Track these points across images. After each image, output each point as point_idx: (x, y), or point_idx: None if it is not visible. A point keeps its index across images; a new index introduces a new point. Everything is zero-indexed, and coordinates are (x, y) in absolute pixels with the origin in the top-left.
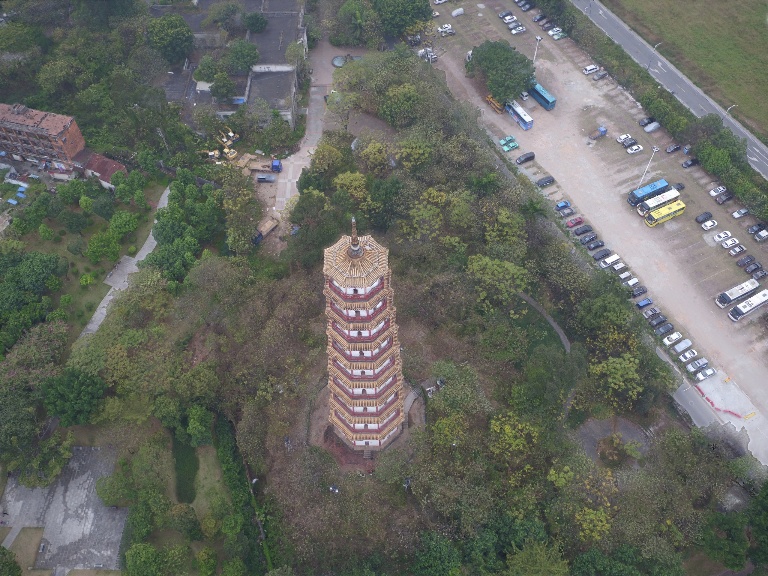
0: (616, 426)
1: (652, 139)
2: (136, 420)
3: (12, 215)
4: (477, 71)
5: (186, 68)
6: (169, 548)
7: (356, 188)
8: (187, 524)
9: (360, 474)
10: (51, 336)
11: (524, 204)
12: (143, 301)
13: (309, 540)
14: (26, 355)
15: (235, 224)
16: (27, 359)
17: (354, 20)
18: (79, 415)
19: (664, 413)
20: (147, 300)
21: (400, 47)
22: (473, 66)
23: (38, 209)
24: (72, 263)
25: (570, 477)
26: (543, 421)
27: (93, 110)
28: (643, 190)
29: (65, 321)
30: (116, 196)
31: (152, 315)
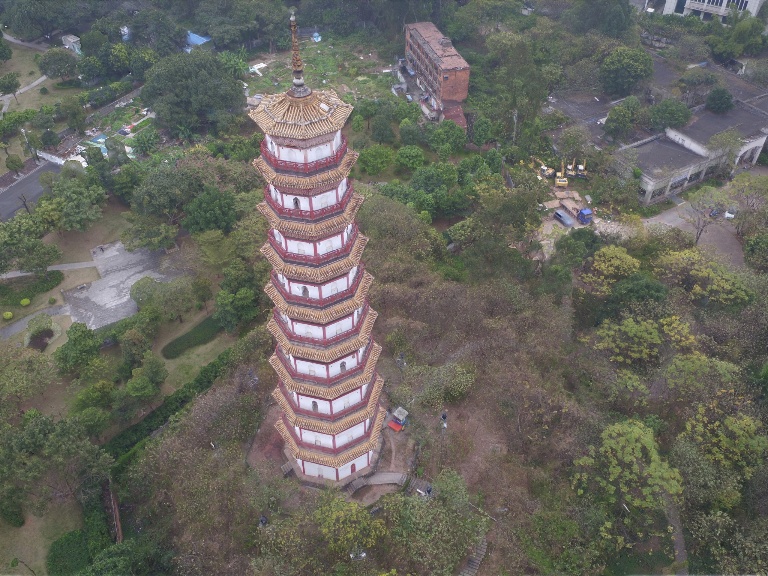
0: None
1: None
2: None
3: (358, 102)
4: None
5: (615, 104)
6: None
7: None
8: (127, 354)
9: None
10: None
11: None
12: None
13: None
14: (231, 168)
15: None
16: (229, 172)
17: None
18: None
19: None
20: None
21: None
22: None
23: (372, 105)
24: None
25: None
26: None
27: None
28: None
29: None
30: None
31: None
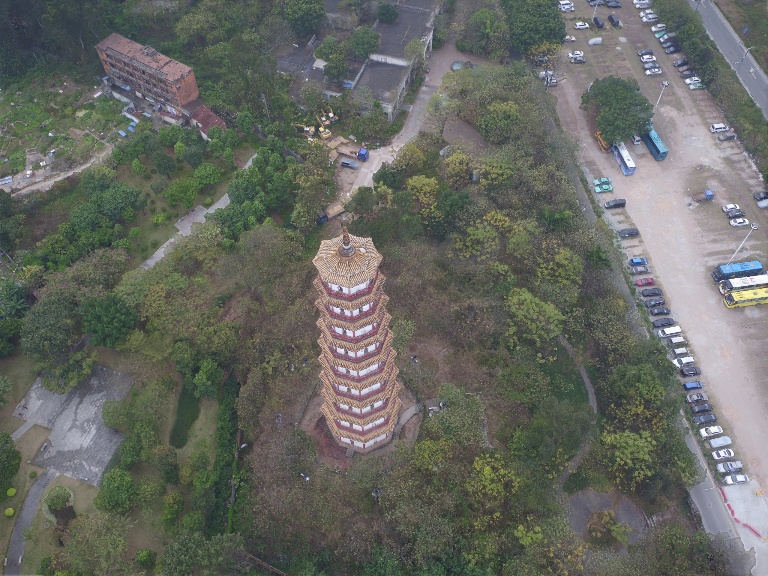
0: (617, 503)
1: (763, 216)
2: (153, 357)
3: (115, 145)
4: (591, 104)
5: (311, 44)
6: (145, 482)
7: (426, 193)
8: (166, 466)
9: (337, 470)
10: (110, 261)
11: (591, 250)
12: (197, 251)
13: (268, 516)
14: (83, 272)
15: (304, 200)
16: (83, 276)
17: (483, 29)
18: (108, 338)
19: (674, 506)
20: (201, 251)
21: (518, 64)
22: (589, 98)
23: (137, 145)
24: (153, 201)
25: (538, 539)
26: (533, 474)
27: (216, 66)
28: (732, 267)
29: (127, 251)
30: (208, 149)
31: (201, 266)
